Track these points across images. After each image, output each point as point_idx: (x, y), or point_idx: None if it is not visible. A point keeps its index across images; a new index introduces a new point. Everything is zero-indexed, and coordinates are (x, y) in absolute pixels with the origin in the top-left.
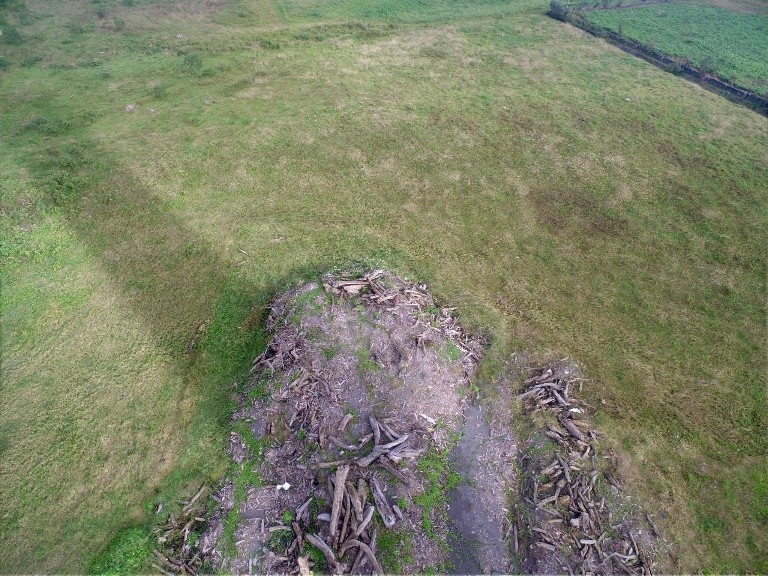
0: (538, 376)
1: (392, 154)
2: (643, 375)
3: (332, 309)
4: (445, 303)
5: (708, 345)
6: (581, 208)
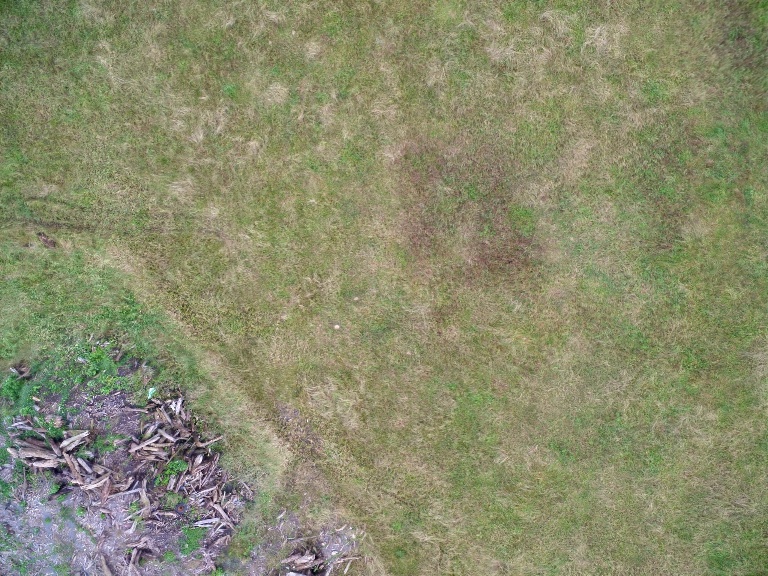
0: (298, 557)
1: (166, 1)
2: (428, 554)
3: (22, 495)
4: (208, 427)
5: (533, 510)
6: (480, 203)
